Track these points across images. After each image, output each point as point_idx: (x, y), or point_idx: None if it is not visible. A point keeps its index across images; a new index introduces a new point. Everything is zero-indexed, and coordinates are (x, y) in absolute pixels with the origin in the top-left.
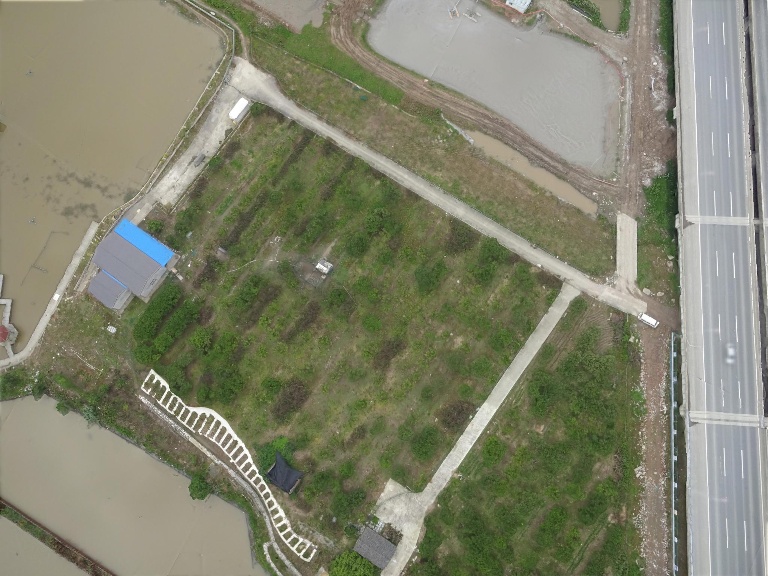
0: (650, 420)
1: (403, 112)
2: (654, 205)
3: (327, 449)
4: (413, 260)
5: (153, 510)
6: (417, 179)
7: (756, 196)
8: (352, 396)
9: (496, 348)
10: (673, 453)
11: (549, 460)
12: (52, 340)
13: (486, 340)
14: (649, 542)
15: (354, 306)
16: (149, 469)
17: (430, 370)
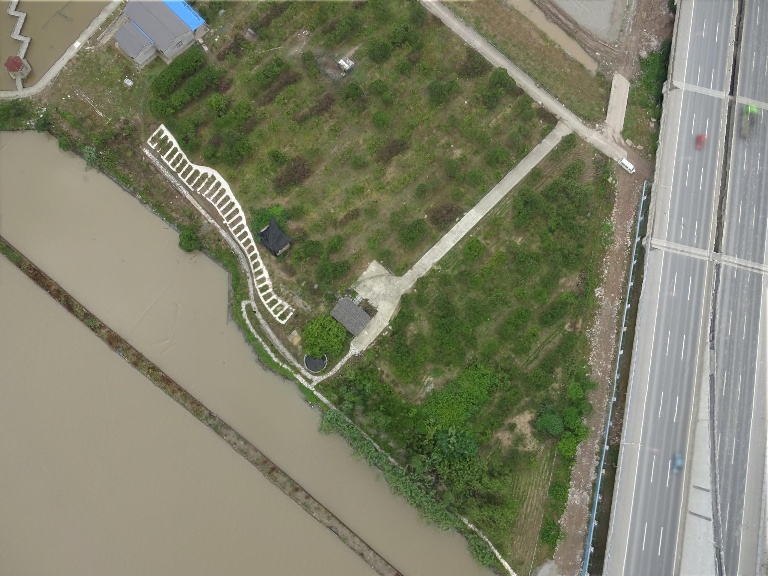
0: (615, 250)
1: None
2: (646, 73)
3: (320, 222)
4: (428, 75)
5: (137, 258)
6: (444, 9)
7: (733, 77)
8: (351, 182)
9: (491, 162)
10: (630, 280)
11: (523, 264)
12: (65, 82)
13: (482, 156)
14: (598, 352)
15: (367, 104)
16: (140, 219)
17: (427, 173)
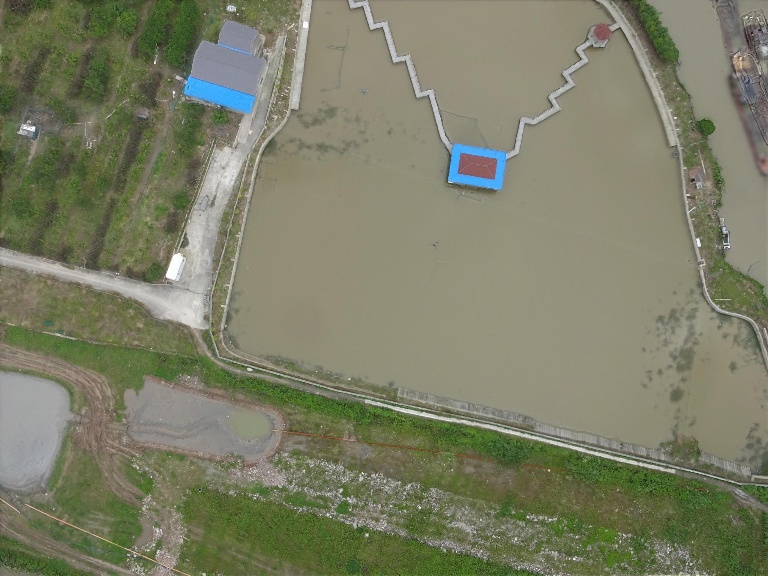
0: None
1: (0, 321)
2: None
3: None
4: None
5: None
6: None
7: None
8: None
9: None
10: None
11: None
12: None
13: None
14: None
15: None
16: None
17: None
